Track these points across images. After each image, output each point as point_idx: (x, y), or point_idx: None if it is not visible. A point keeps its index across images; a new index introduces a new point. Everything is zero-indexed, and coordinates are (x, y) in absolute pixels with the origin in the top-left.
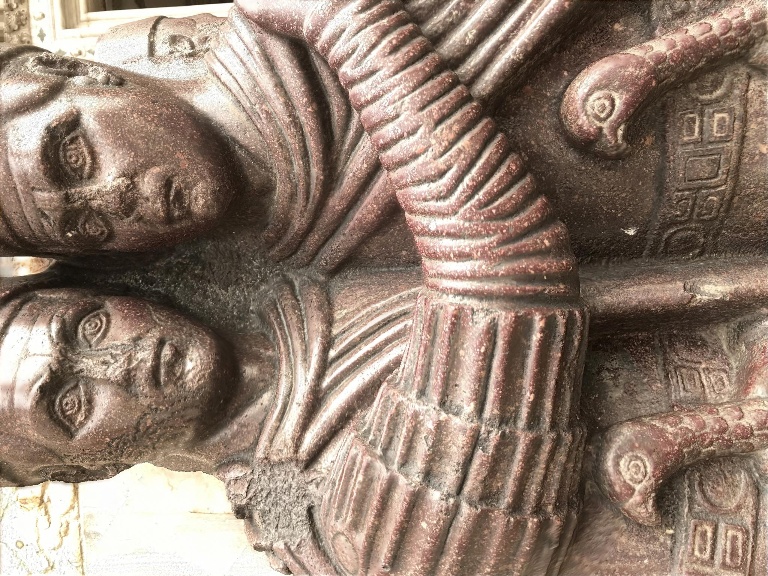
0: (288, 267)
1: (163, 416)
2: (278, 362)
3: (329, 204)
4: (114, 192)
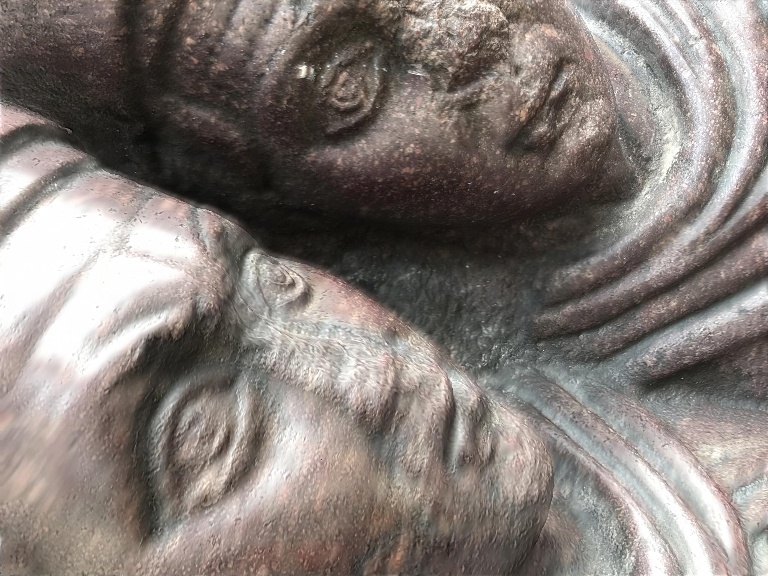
0: (550, 357)
1: (431, 568)
2: (585, 523)
3: (751, 245)
4: (475, 19)
